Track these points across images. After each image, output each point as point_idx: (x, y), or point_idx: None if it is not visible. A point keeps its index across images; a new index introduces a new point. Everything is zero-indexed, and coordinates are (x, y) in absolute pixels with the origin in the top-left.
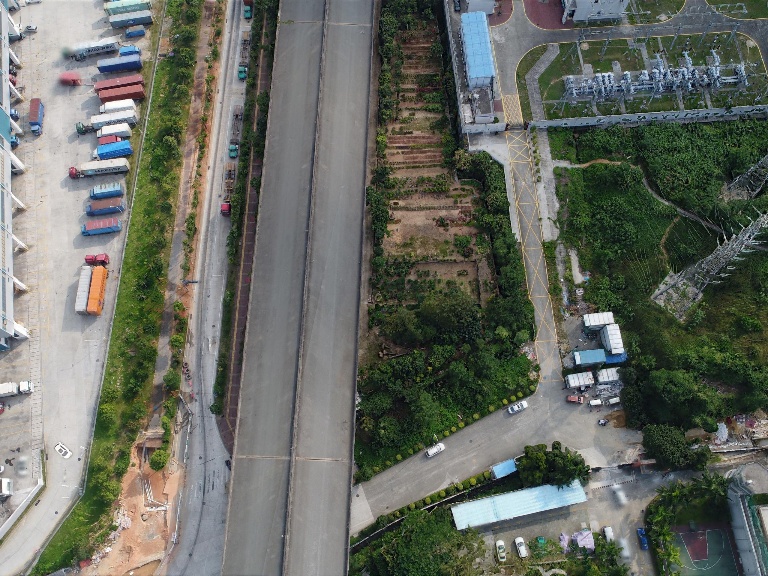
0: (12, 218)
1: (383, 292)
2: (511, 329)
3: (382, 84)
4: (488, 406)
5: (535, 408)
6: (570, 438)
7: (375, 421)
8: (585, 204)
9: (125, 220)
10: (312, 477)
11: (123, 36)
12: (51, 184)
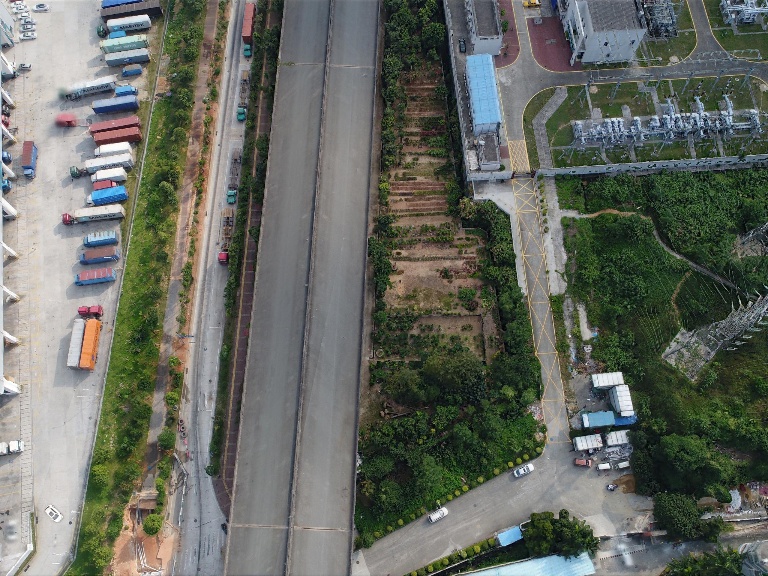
0: (3, 267)
1: (385, 348)
2: (517, 388)
3: (385, 128)
4: (493, 469)
5: (541, 471)
6: (578, 504)
7: (376, 483)
8: (594, 256)
9: (120, 269)
10: (311, 548)
11: (119, 75)
12: (44, 230)
